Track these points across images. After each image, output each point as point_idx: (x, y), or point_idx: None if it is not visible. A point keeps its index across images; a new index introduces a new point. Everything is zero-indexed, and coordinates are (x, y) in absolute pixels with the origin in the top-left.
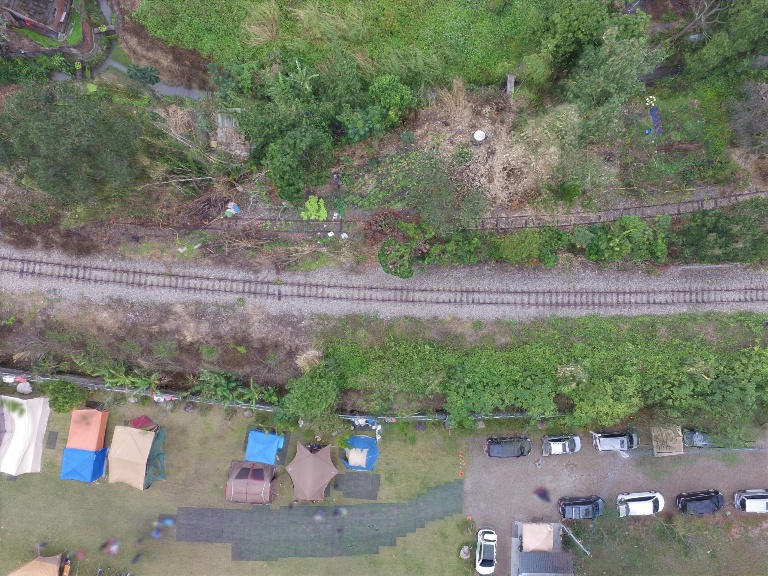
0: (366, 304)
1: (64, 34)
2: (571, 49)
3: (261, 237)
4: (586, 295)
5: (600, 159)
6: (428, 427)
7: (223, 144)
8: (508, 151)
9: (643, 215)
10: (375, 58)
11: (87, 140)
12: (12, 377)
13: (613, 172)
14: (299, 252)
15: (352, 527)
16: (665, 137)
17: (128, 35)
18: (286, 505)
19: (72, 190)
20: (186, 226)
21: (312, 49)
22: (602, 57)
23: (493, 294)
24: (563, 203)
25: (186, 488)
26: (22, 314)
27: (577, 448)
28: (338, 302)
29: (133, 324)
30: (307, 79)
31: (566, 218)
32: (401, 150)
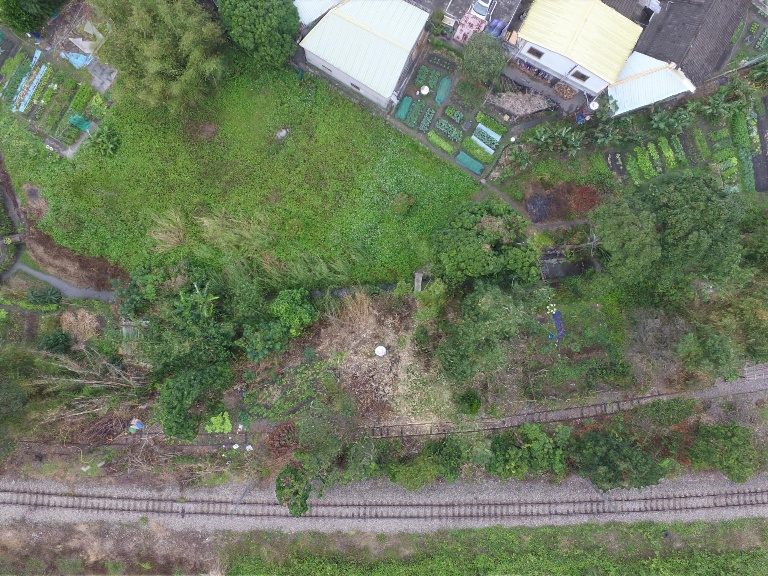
0: (270, 520)
1: None
2: (463, 279)
3: (165, 452)
4: (488, 507)
5: (503, 366)
6: None
7: (128, 357)
8: (412, 359)
9: (547, 419)
10: (282, 261)
11: None
12: None
13: (515, 380)
14: (202, 470)
15: None
16: (568, 341)
17: (35, 243)
18: None
19: None
20: None
21: (219, 253)
22: None
23: (396, 508)
24: None
25: None
26: None
27: None
28: (242, 519)
29: (37, 544)
30: (207, 301)
31: (470, 424)
32: (305, 361)
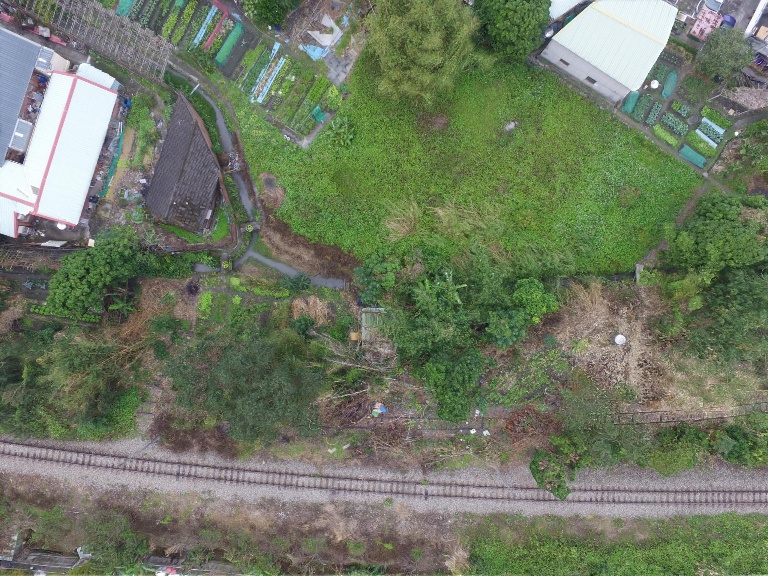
0: (510, 503)
1: (208, 229)
2: (718, 270)
3: (406, 436)
4: (723, 494)
5: None
6: None
7: (367, 342)
8: (644, 349)
9: None
10: (509, 251)
11: (290, 411)
12: (165, 572)
13: (746, 370)
14: (446, 454)
15: None
16: None
17: (271, 231)
18: None
19: (257, 435)
20: (334, 426)
21: (448, 243)
22: (761, 296)
23: (633, 493)
24: (697, 399)
25: None
26: (177, 514)
27: None
28: (483, 501)
29: (284, 523)
30: (455, 288)
31: (699, 413)
32: (540, 348)
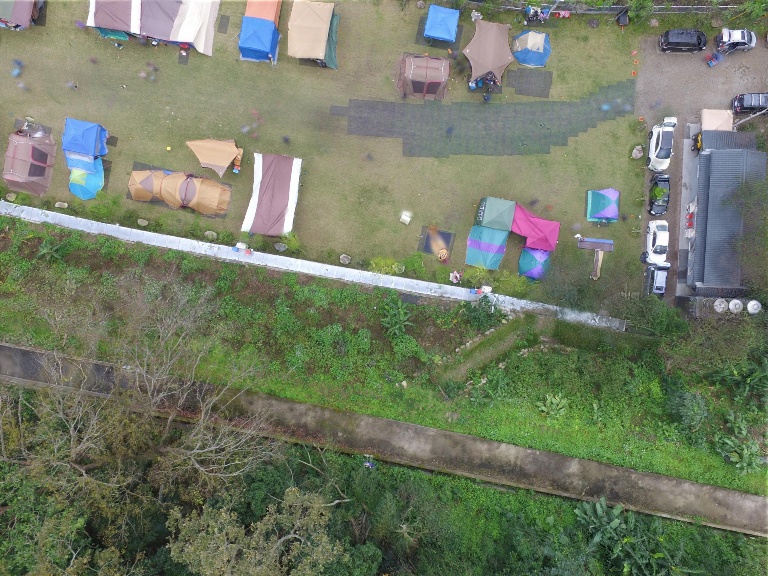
0: None
1: None
2: None
3: None
4: None
5: None
6: (601, 24)
7: None
8: None
9: None
10: None
11: None
12: None
13: None
14: None
15: (524, 125)
16: None
17: None
18: (458, 101)
19: None
20: None
21: None
22: None
23: None
24: None
25: (358, 80)
26: None
27: (753, 42)
28: None
29: None
30: None
31: None
32: None
